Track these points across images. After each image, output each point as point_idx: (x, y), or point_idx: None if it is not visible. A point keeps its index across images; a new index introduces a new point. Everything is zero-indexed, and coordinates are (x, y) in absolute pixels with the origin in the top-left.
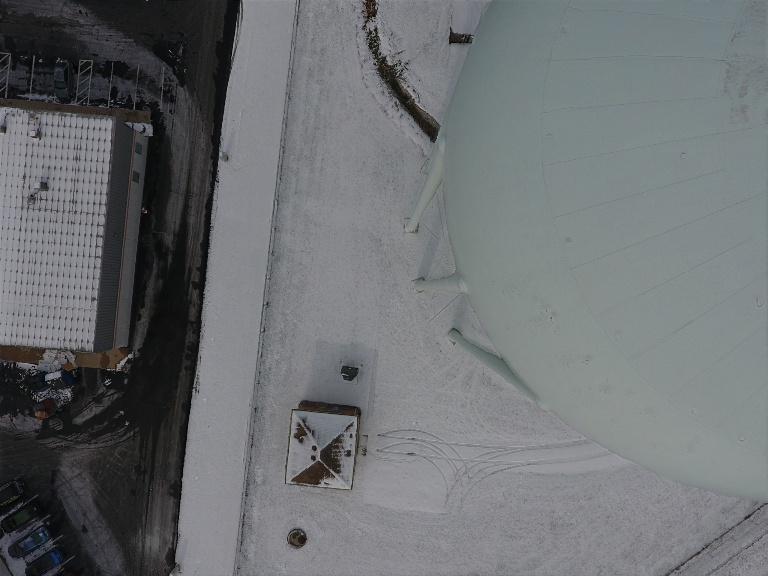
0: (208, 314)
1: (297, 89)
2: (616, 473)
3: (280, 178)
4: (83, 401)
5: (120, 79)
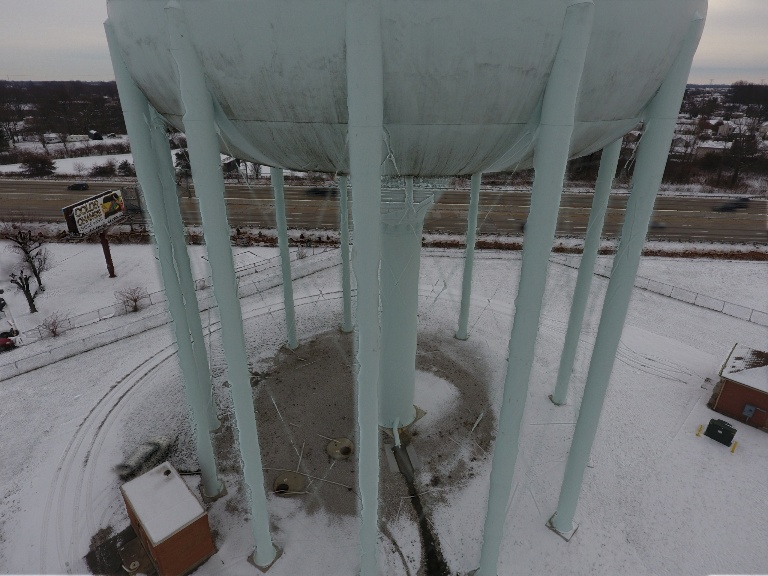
0: None
1: None
2: None
3: None
4: None
5: None
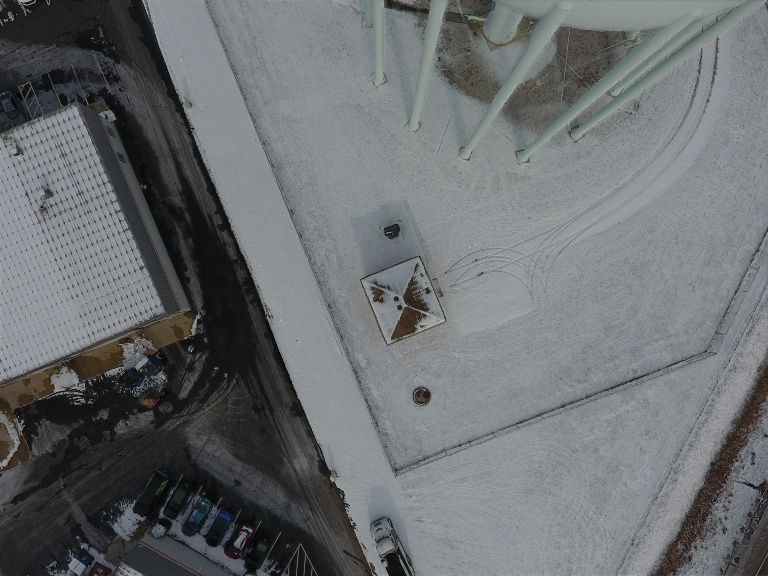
0: (245, 246)
1: (219, 14)
2: (664, 197)
3: (245, 98)
4: (178, 376)
5: (62, 85)
